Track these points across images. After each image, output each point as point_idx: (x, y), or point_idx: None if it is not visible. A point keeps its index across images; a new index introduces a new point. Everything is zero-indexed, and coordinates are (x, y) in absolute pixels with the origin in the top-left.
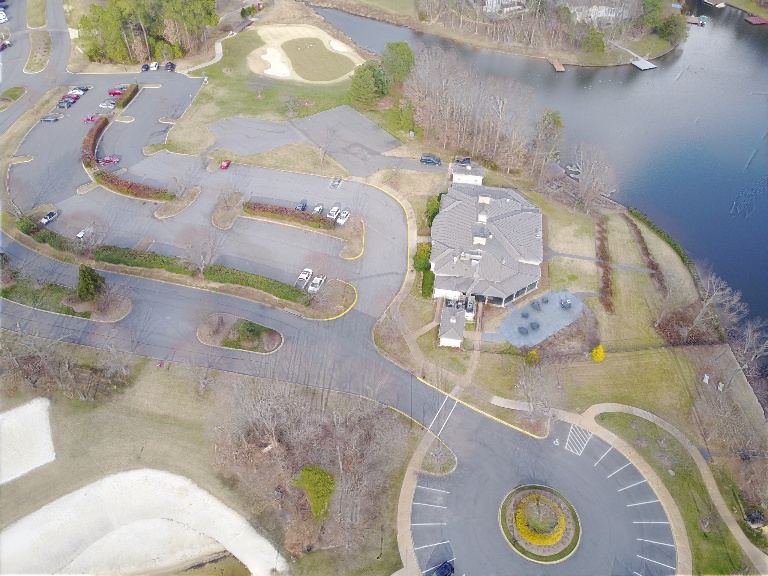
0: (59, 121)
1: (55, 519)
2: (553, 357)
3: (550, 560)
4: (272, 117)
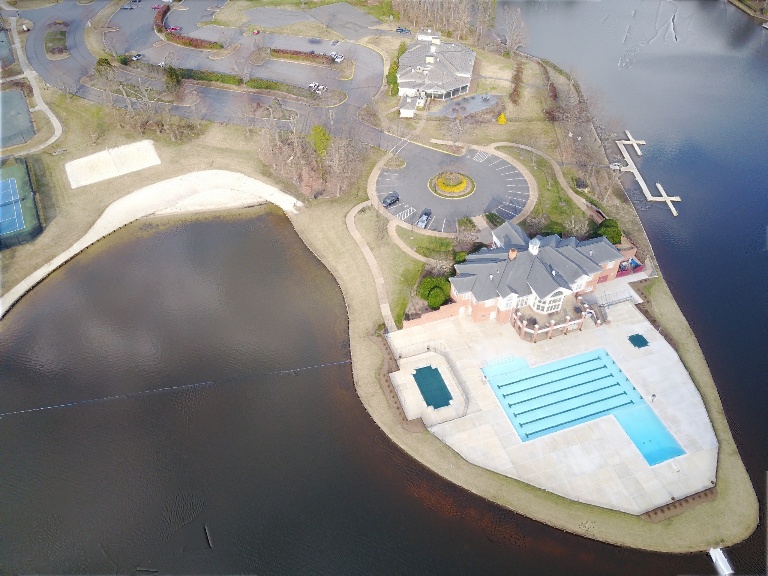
0: (134, 9)
1: (164, 188)
2: (473, 122)
3: (455, 197)
4: (289, 7)
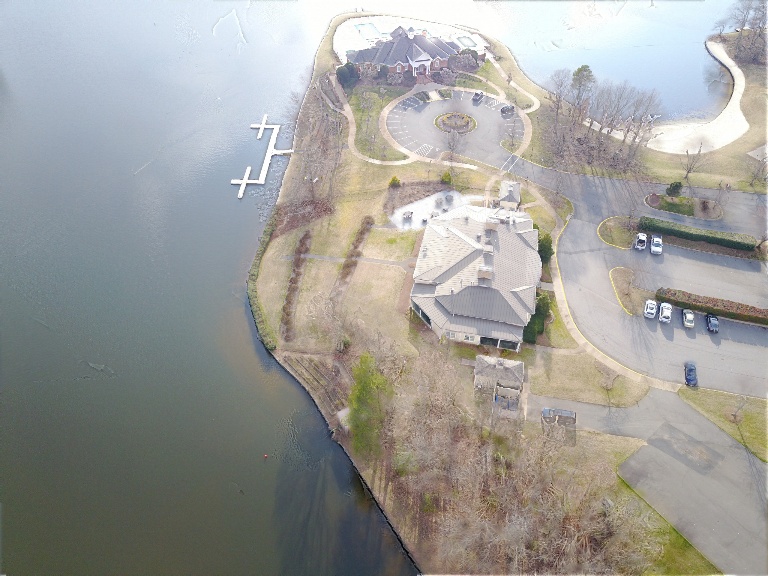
0: None
1: (719, 139)
2: (429, 184)
3: None
4: None
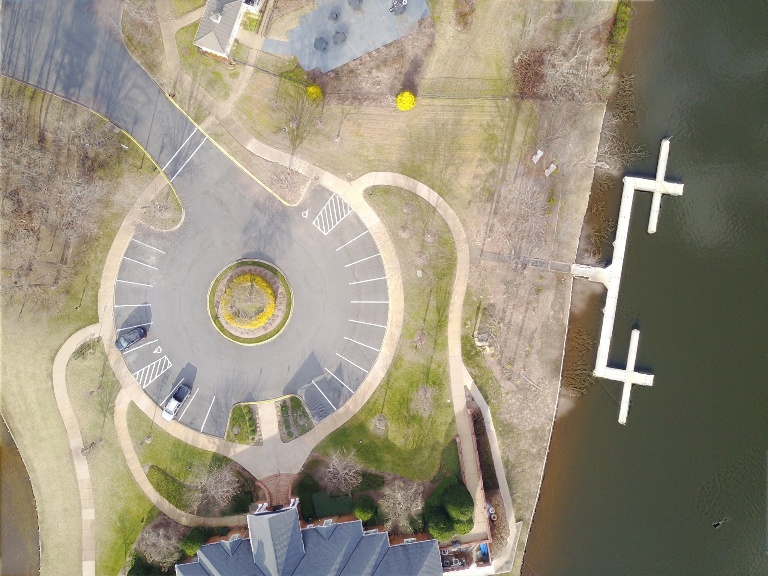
0: None
1: None
2: (346, 94)
3: (245, 342)
4: None
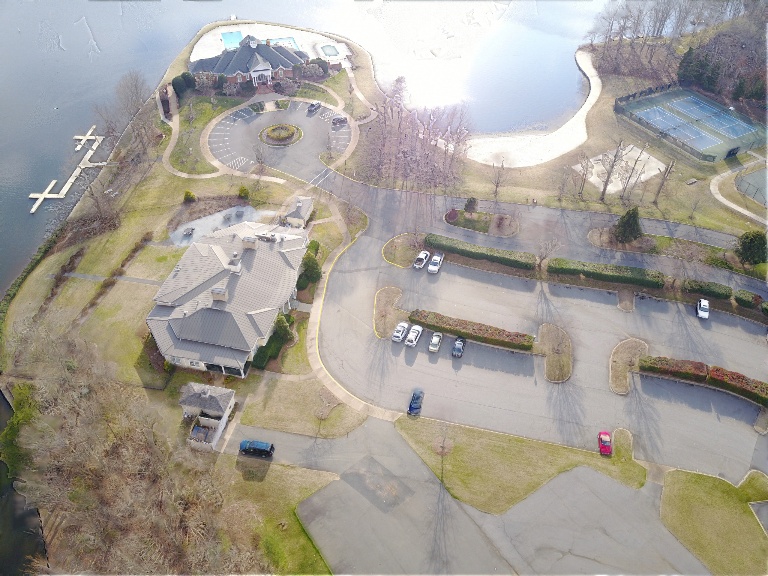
0: None
1: (551, 152)
2: (226, 199)
3: None
4: None
